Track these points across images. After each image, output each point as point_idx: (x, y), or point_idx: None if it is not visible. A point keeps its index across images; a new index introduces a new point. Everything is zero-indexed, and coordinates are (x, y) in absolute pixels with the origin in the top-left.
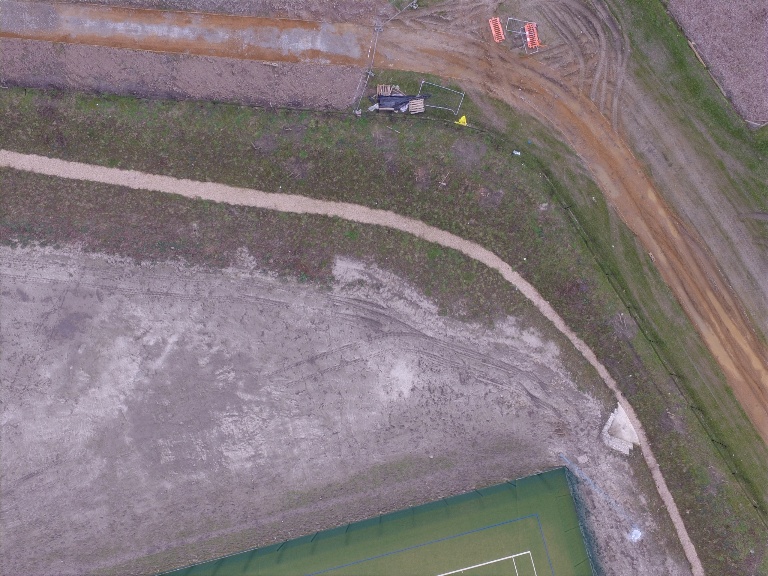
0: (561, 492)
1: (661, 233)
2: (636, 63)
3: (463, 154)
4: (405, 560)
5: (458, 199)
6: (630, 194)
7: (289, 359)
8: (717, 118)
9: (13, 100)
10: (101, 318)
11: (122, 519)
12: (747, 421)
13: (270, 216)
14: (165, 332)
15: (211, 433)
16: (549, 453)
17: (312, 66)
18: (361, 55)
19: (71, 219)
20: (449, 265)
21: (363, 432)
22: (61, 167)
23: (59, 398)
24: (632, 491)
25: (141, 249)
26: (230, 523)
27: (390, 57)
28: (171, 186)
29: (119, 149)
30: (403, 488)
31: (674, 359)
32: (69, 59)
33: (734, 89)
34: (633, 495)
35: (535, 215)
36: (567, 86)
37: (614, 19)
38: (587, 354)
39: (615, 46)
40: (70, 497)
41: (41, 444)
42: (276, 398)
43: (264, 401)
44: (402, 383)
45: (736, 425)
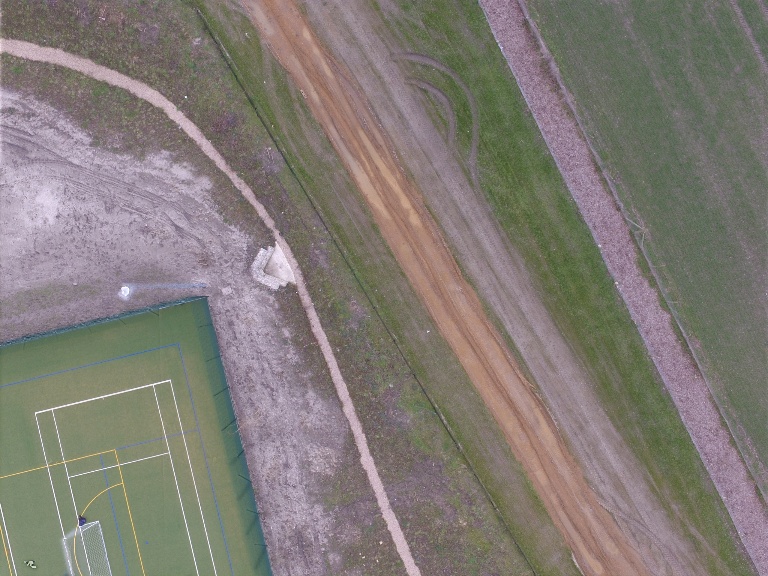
0: (203, 322)
1: (313, 71)
2: None
3: None
4: (47, 386)
5: (120, 35)
6: (284, 32)
7: None
8: None
9: None
10: None
11: None
12: (392, 258)
13: None
14: None
15: None
16: (192, 283)
17: None
18: None
19: None
20: (113, 102)
21: (8, 258)
22: None
23: None
24: (274, 323)
25: None
26: None
27: None
28: None
29: None
30: (47, 315)
31: (321, 194)
32: None
33: None
34: (275, 327)
35: (188, 49)
36: None
37: None
38: (247, 193)
39: None
40: None
41: None
42: None
43: None
44: (47, 210)
45: (381, 261)
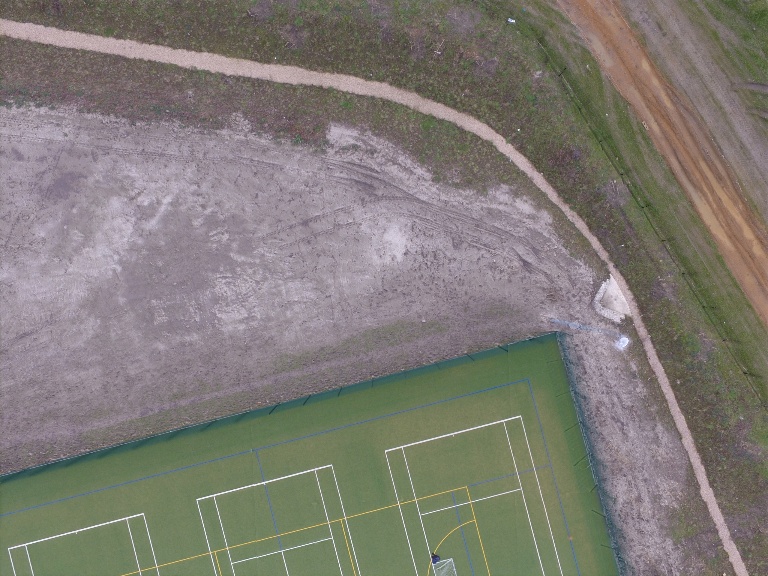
0: (552, 357)
1: (655, 102)
2: None
3: (458, 22)
4: (397, 424)
5: (453, 69)
6: (624, 63)
7: (283, 221)
8: None
9: None
10: (96, 178)
11: (115, 380)
12: (738, 289)
13: (265, 86)
14: (159, 193)
15: (204, 294)
16: (541, 318)
17: None
18: None
19: (66, 84)
20: (443, 136)
21: (356, 296)
22: (57, 36)
23: (53, 257)
24: (623, 357)
25: (136, 111)
26: (223, 386)
27: None
28: (167, 56)
29: (115, 17)
30: (395, 352)
31: (666, 227)
32: None
33: None
34: (624, 361)
35: (529, 83)
36: None
37: None
38: (580, 226)
39: None
40: (64, 357)
41: (35, 303)
42: (269, 260)
43: (257, 263)
44: (395, 247)
45: (727, 293)
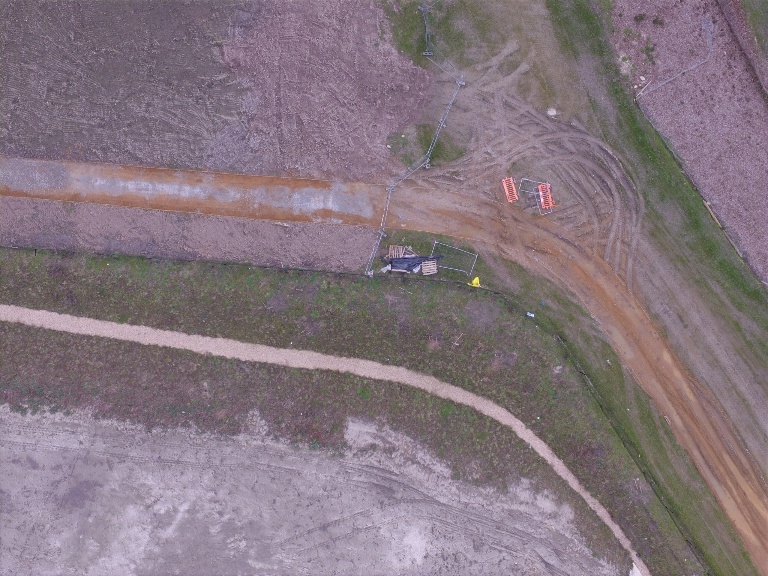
0: None
1: (677, 396)
2: (651, 223)
3: (476, 315)
4: None
5: (471, 358)
6: (645, 356)
7: (301, 527)
8: (733, 279)
9: (23, 260)
10: (111, 486)
11: None
12: None
13: (281, 373)
14: (176, 500)
15: None
16: None
17: (324, 226)
18: (373, 215)
19: (81, 380)
20: (462, 423)
21: None
22: (71, 323)
23: (69, 567)
24: None
25: (152, 414)
26: None
27: (402, 217)
28: (181, 342)
29: (129, 306)
30: None
31: (690, 524)
32: (79, 218)
33: (750, 250)
34: None
35: (549, 378)
36: (581, 246)
37: (628, 179)
38: (602, 514)
39: (630, 206)
40: None
41: None
42: (288, 566)
43: (276, 569)
44: (415, 550)
45: None
